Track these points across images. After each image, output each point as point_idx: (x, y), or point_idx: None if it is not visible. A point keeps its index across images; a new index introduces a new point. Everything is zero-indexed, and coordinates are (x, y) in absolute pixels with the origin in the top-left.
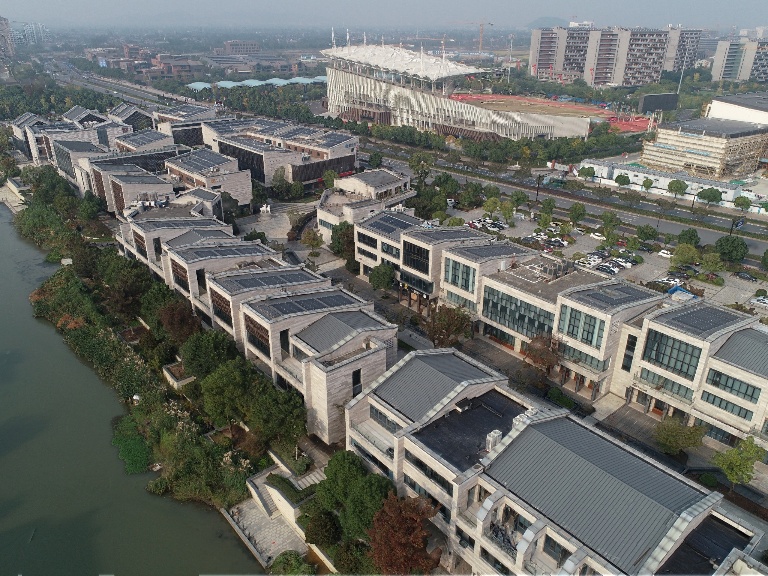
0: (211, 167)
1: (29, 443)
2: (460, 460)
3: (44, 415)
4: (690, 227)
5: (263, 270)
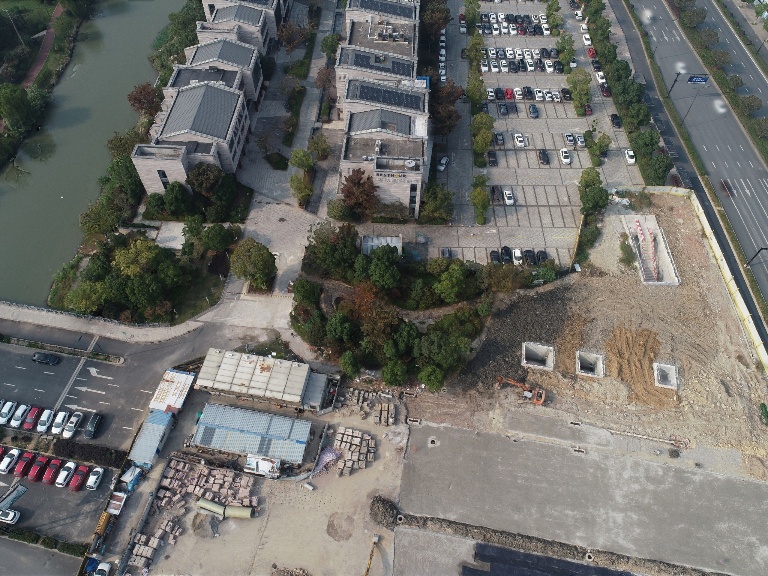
0: None
1: (137, 17)
2: (180, 85)
3: (153, 8)
4: (701, 69)
5: None
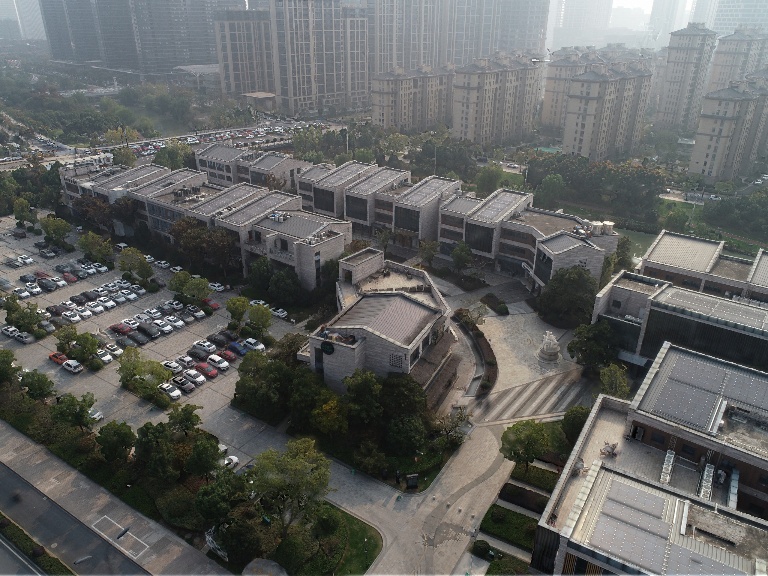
0: (657, 285)
1: None
2: None
3: None
4: None
5: (387, 182)
